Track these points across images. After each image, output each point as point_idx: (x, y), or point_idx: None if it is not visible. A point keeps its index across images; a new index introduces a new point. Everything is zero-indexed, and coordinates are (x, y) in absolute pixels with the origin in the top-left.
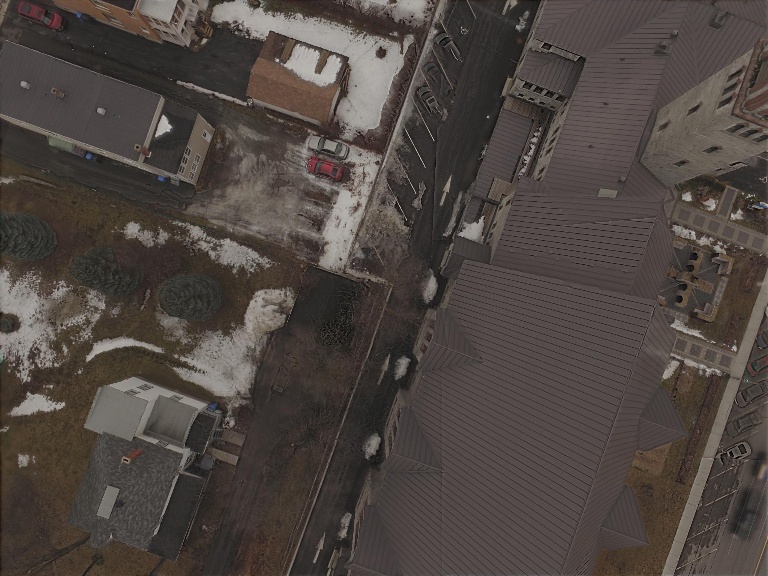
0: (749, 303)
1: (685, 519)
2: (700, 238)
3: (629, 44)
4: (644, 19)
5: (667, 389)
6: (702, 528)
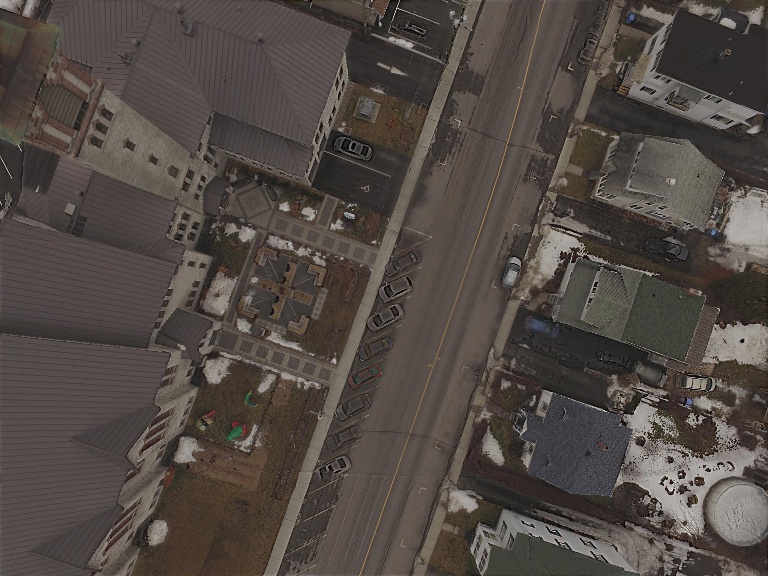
0: (349, 315)
1: (282, 535)
2: (298, 249)
3: (116, 53)
4: (124, 28)
5: (263, 403)
6: (301, 544)
